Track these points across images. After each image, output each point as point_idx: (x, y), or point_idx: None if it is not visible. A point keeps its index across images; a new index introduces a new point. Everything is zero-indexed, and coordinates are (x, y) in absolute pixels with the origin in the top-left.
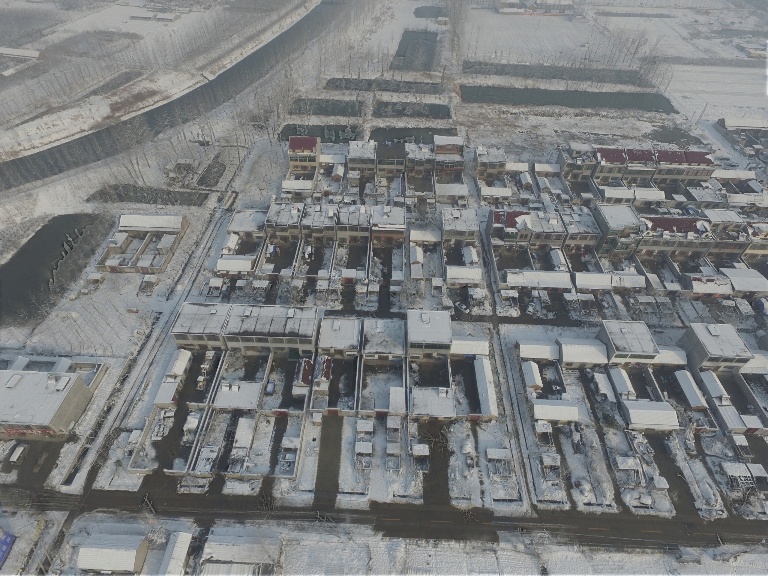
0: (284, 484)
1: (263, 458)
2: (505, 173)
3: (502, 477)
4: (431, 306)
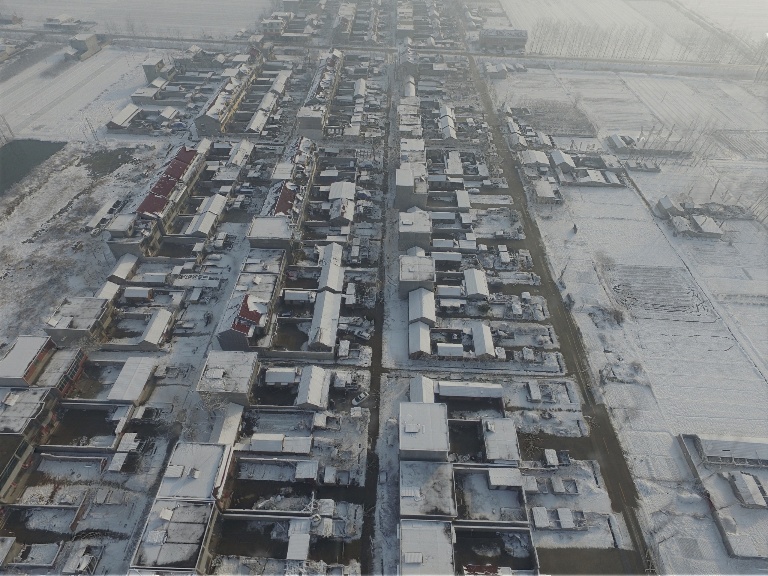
0: None
1: None
2: None
3: None
4: (357, 433)
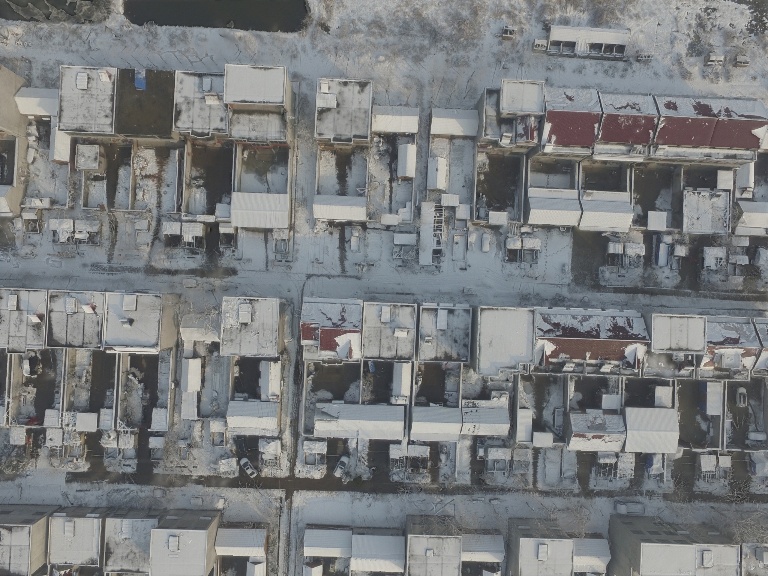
0: None
1: None
2: (376, 133)
3: None
4: (208, 464)
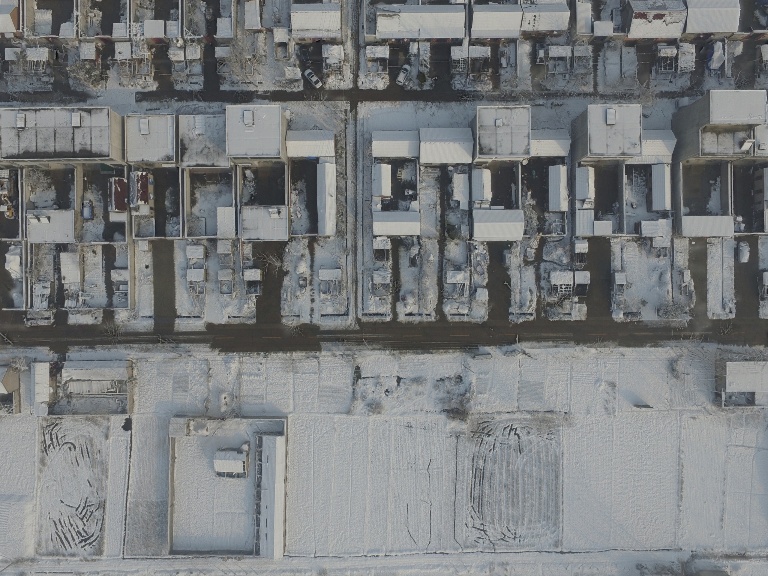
0: (123, 314)
1: (98, 290)
2: None
3: (332, 296)
4: (273, 78)
